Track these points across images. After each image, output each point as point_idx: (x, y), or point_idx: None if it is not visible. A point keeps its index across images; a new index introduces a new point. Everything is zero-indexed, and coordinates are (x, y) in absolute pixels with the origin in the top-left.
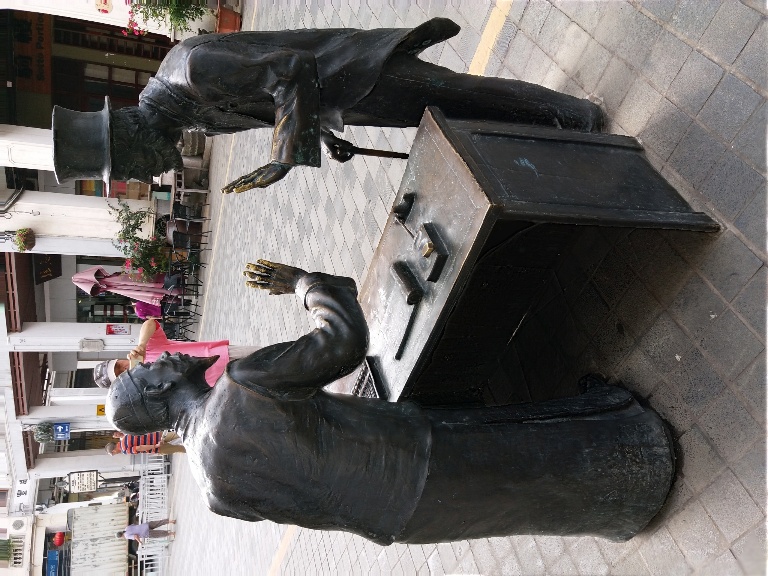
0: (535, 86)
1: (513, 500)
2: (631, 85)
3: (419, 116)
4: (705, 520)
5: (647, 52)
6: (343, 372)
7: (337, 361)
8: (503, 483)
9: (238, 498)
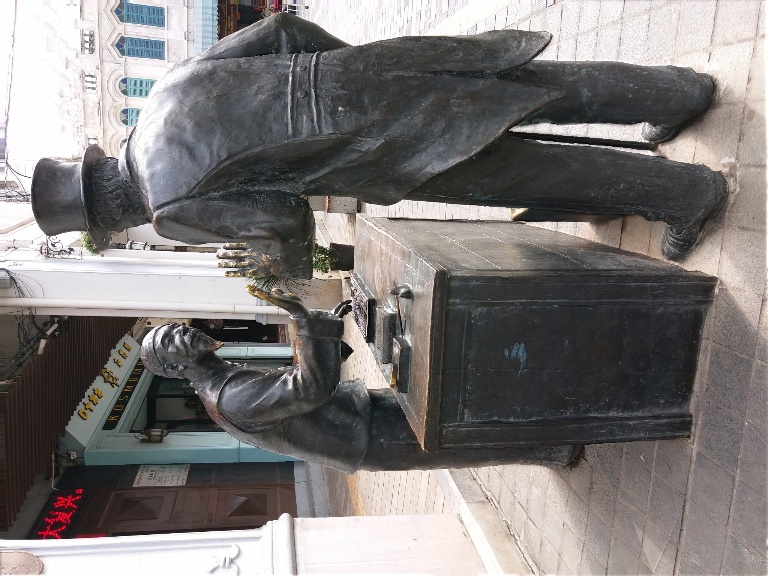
0: (635, 184)
1: None
2: (762, 231)
3: None
4: (565, 497)
5: None
6: None
7: (302, 411)
8: None
9: None
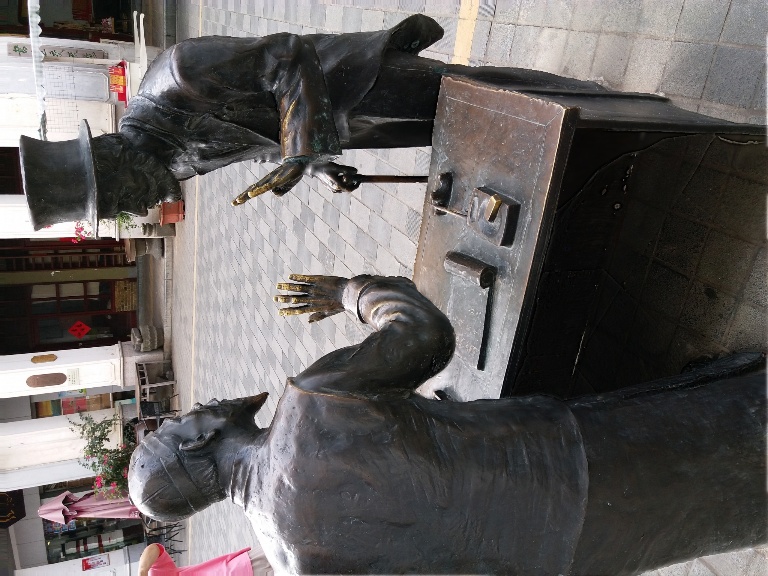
0: None
1: (693, 491)
2: (630, 50)
3: (428, 109)
4: None
5: (638, 12)
6: (435, 367)
7: (426, 349)
8: (677, 465)
9: (338, 570)
